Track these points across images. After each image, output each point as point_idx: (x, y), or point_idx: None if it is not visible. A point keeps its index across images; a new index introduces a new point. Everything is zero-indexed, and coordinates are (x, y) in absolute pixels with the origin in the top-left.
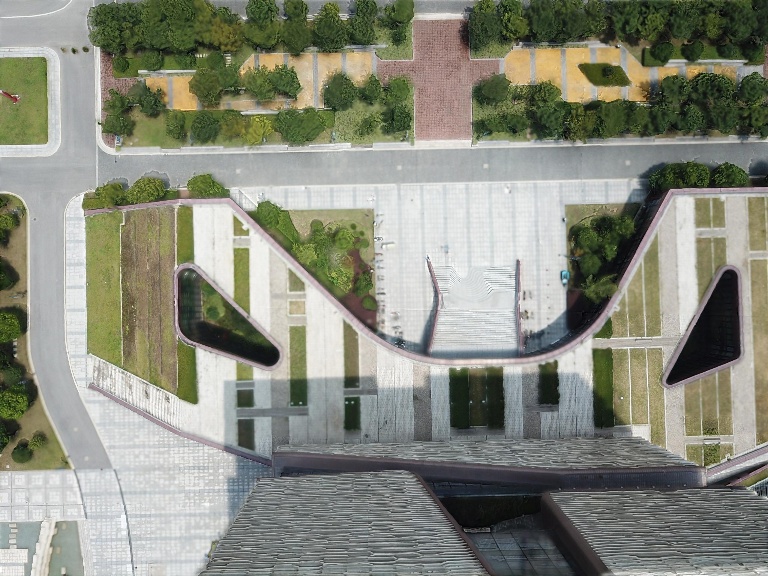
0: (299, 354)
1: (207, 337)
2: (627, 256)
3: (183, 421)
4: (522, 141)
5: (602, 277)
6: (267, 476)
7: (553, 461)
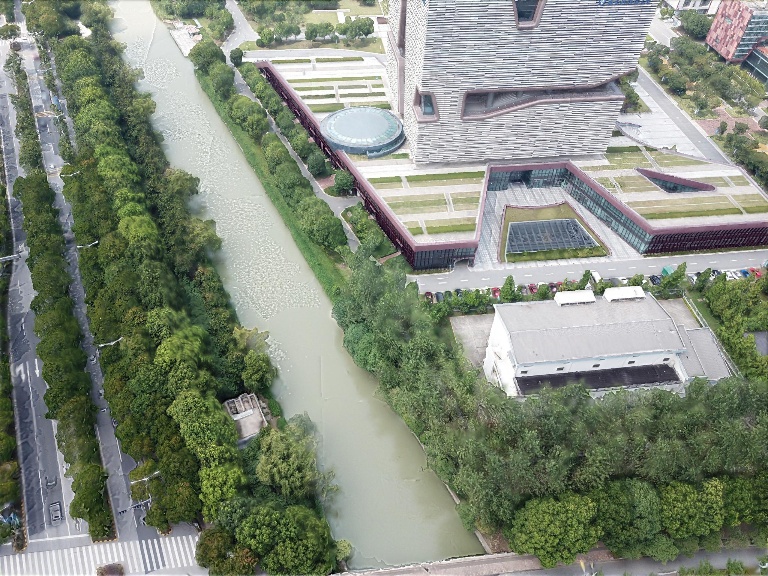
0: None
1: None
2: None
3: None
4: (722, 150)
5: None
6: None
7: None
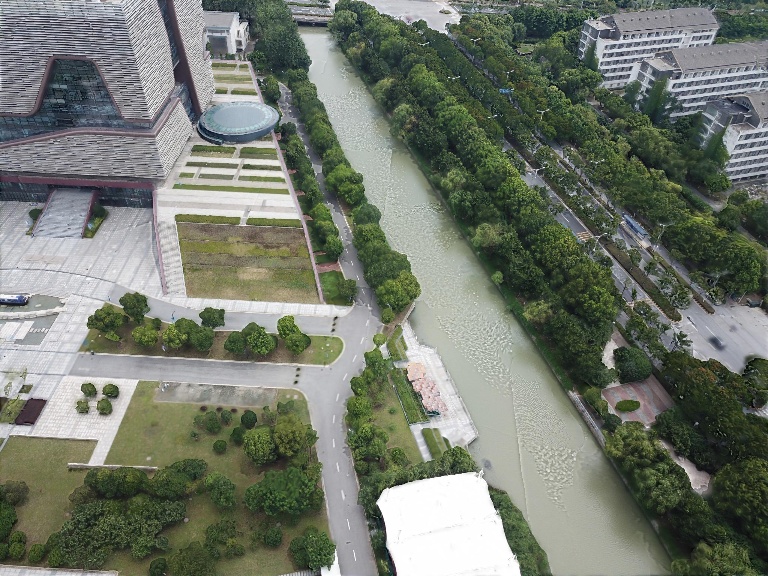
0: None
1: None
2: None
3: None
4: None
5: None
6: (4, 212)
7: None
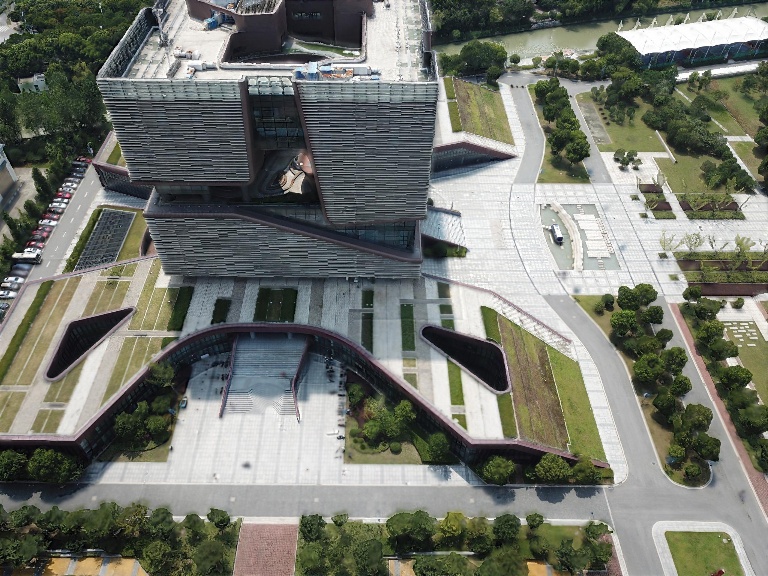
0: (407, 333)
1: (484, 371)
2: (128, 405)
3: (490, 298)
4: None
5: (153, 399)
6: None
7: (236, 233)
